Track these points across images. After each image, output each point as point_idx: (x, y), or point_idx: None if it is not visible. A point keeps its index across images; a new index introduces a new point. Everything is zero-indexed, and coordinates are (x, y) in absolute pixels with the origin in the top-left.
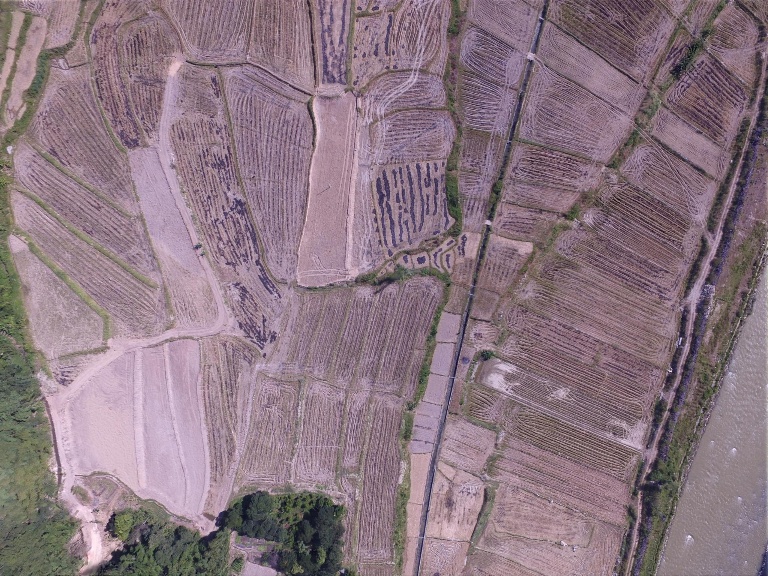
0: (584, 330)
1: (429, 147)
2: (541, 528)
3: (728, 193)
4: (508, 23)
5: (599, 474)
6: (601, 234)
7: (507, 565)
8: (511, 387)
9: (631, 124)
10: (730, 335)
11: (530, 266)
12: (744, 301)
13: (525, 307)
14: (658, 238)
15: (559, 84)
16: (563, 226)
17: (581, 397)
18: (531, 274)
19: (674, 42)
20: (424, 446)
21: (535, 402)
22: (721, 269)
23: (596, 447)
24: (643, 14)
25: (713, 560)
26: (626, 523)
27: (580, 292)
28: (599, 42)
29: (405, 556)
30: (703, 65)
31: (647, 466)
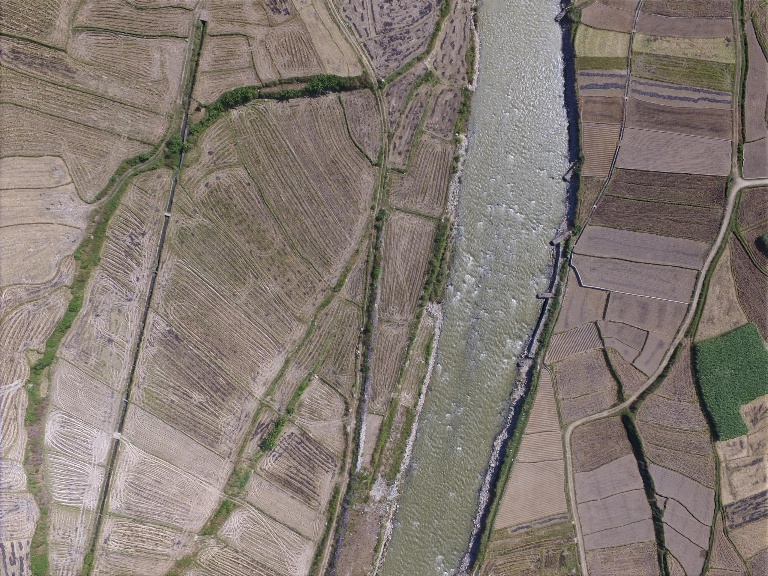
0: None
1: (12, 527)
2: None
3: (322, 555)
4: (92, 405)
5: None
6: None
7: None
8: None
9: (221, 496)
10: None
11: None
12: None
13: None
14: None
15: (147, 461)
16: None
17: None
18: None
19: (261, 418)
20: None
21: None
22: None
23: None
24: (226, 396)
25: None
26: None
27: None
28: (184, 422)
29: None
30: (293, 436)
31: None
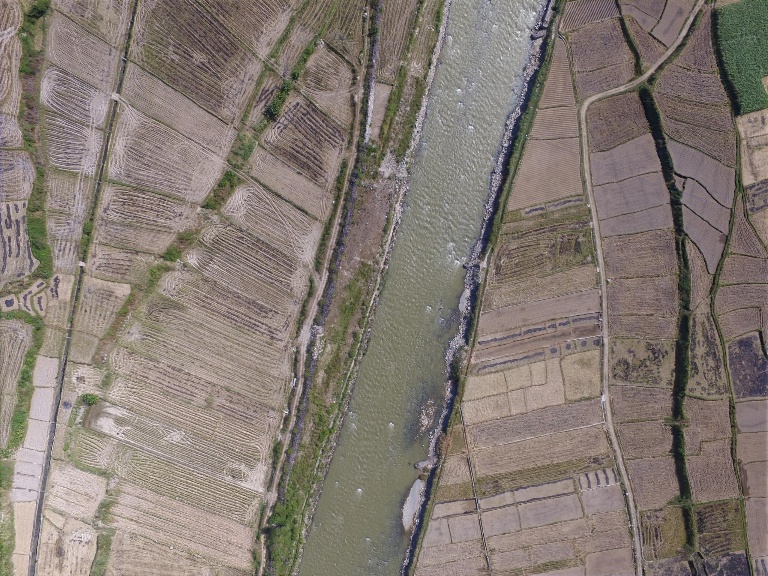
0: (195, 372)
1: (8, 188)
2: (163, 575)
3: (330, 234)
4: (89, 63)
5: (220, 518)
6: (206, 275)
7: None
8: (122, 431)
9: (224, 165)
10: (344, 375)
11: (132, 308)
12: (355, 341)
13: (131, 349)
14: (265, 279)
15: (147, 125)
16: (162, 267)
17: (197, 440)
18: (135, 316)
19: (265, 84)
20: (28, 494)
21: (148, 446)
22: (326, 310)
23: (215, 491)
24: (228, 56)
25: None
26: (251, 568)
27: (188, 333)
28: (185, 83)
29: None
30: (298, 107)
31: (268, 509)
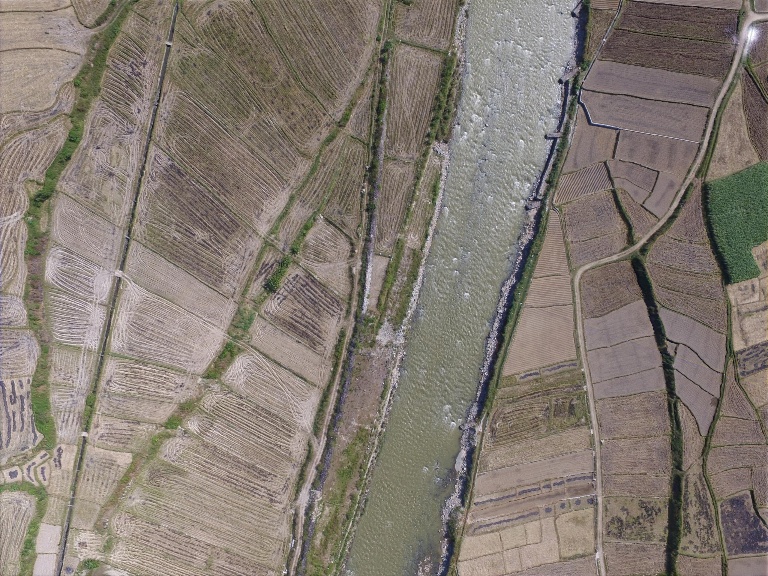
0: (195, 535)
1: (13, 365)
2: None
3: (328, 401)
4: (93, 242)
5: None
6: (207, 440)
7: None
8: None
9: (225, 337)
10: (342, 536)
11: (134, 474)
12: (353, 503)
13: (132, 514)
14: (264, 443)
15: (149, 300)
16: (164, 435)
17: None
18: (137, 481)
19: (265, 258)
20: None
21: None
22: (324, 475)
23: None
24: (229, 233)
25: None
26: None
27: (188, 498)
28: (186, 260)
29: None
30: (297, 278)
31: None
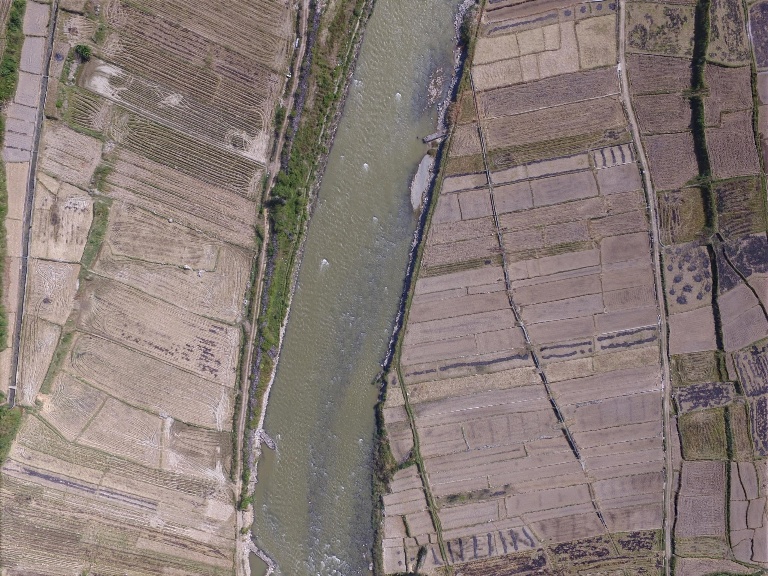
0: (192, 29)
1: None
2: (162, 251)
3: None
4: None
5: (221, 190)
6: None
7: (128, 292)
8: (117, 92)
9: None
10: (349, 36)
11: None
12: None
13: (126, 1)
14: None
15: None
16: None
17: (195, 104)
18: None
19: None
20: (20, 154)
21: (145, 109)
22: None
23: (215, 160)
24: None
25: (351, 286)
26: (254, 245)
27: None
28: None
29: (7, 278)
30: None
31: (271, 180)
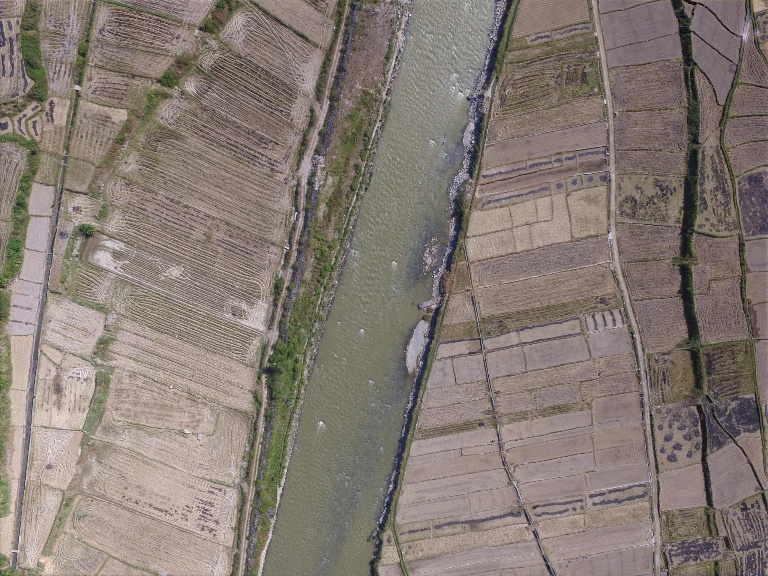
0: (194, 205)
1: (1, 4)
2: (162, 416)
3: (331, 60)
4: None
5: (221, 357)
6: (205, 103)
7: (129, 456)
8: (120, 265)
9: None
10: (346, 209)
11: (129, 136)
12: (357, 174)
13: (129, 180)
14: (265, 108)
15: None
16: (160, 93)
17: (196, 276)
18: (132, 145)
19: None
20: (25, 328)
21: (147, 281)
22: (327, 139)
23: (215, 329)
24: None
25: (347, 447)
26: (253, 409)
27: (186, 164)
28: None
29: (11, 446)
30: None
31: (269, 348)
